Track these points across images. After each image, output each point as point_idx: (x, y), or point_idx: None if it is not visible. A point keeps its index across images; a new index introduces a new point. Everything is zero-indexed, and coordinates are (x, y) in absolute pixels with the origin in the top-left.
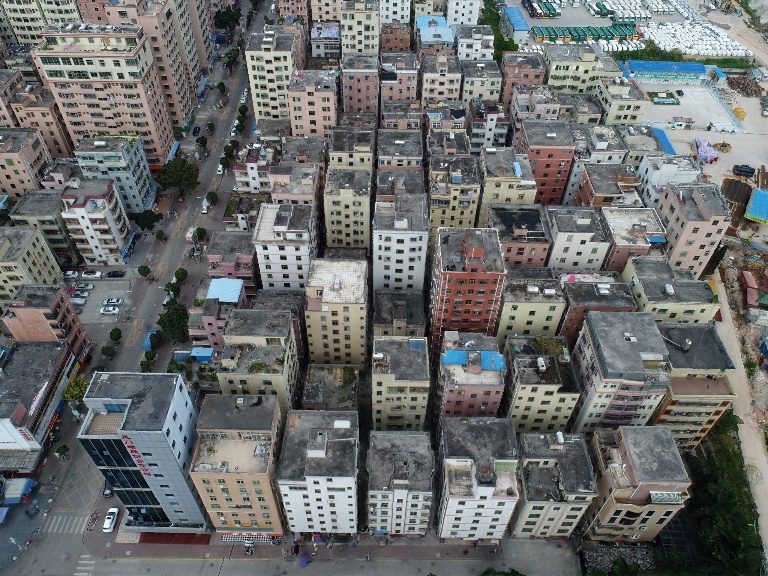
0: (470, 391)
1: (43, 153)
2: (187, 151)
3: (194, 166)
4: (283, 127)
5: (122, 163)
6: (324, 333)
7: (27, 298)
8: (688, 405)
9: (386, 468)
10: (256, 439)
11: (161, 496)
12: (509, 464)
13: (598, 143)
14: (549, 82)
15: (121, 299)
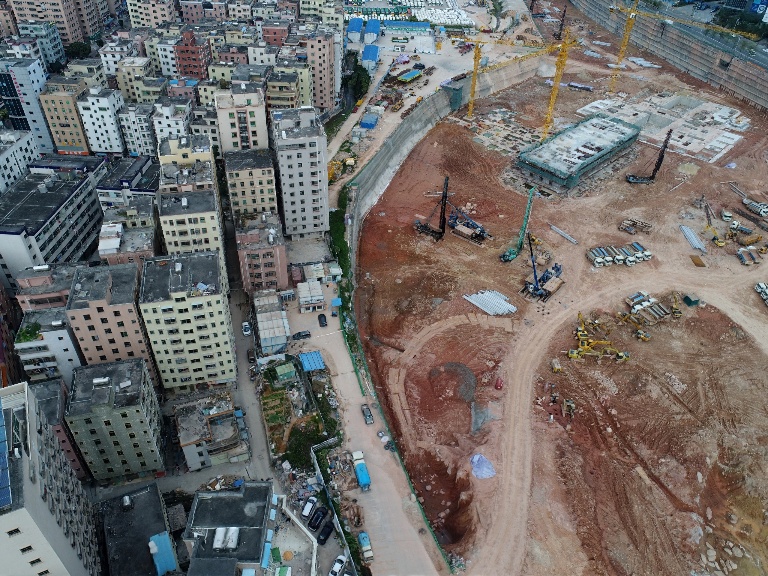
0: (178, 92)
1: (2, 32)
2: (92, 50)
3: (88, 45)
4: None
5: (43, 32)
6: (127, 88)
7: None
8: (276, 100)
9: None
10: (71, 91)
11: (31, 122)
12: (182, 108)
13: (299, 27)
14: (301, 12)
15: None
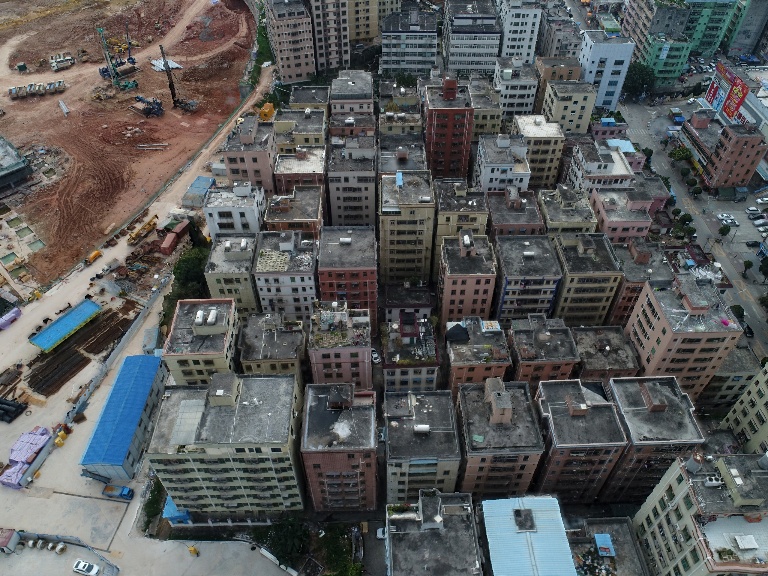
0: None
1: None
2: None
3: None
4: None
5: None
6: None
7: (748, 127)
8: None
9: (482, 85)
10: None
11: None
12: None
13: (293, 231)
14: None
15: (725, 223)
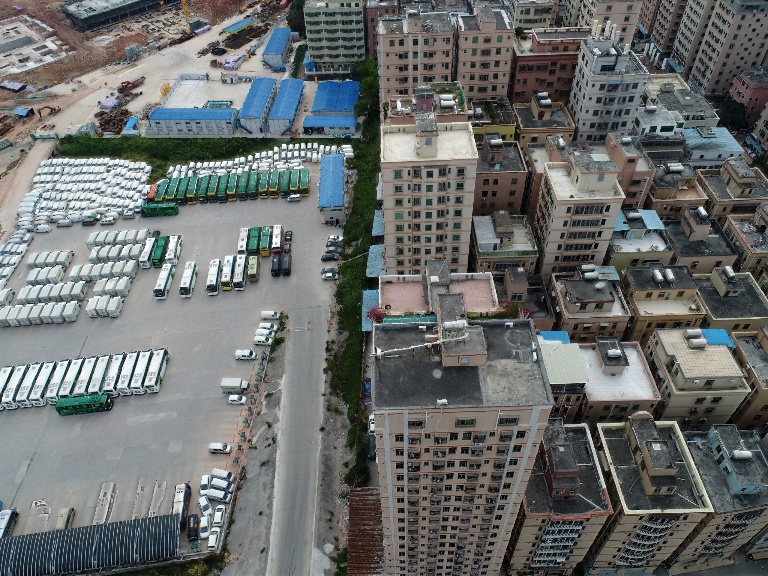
0: None
1: None
2: None
3: None
4: (563, 12)
5: None
6: None
7: None
8: None
9: None
10: None
11: None
12: None
13: None
14: None
15: None
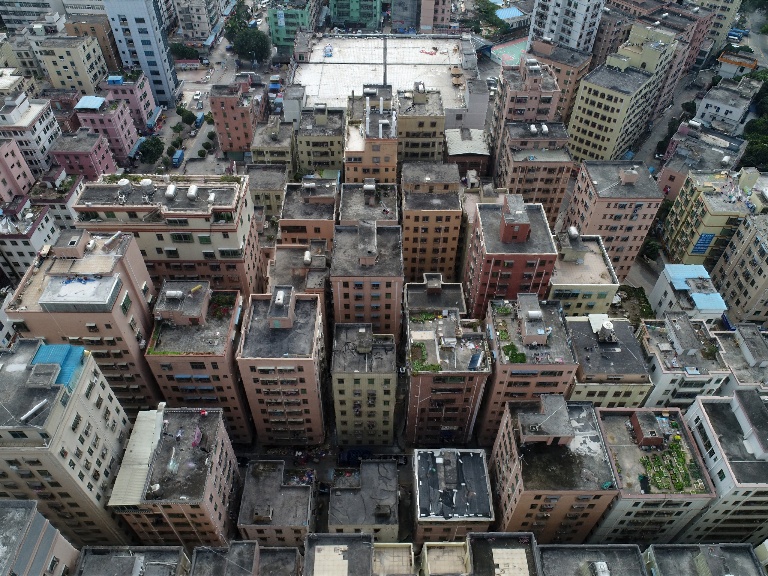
0: None
1: None
2: None
3: None
4: None
5: None
6: None
7: (229, 88)
8: None
9: None
10: None
11: None
12: None
13: None
14: None
15: None
